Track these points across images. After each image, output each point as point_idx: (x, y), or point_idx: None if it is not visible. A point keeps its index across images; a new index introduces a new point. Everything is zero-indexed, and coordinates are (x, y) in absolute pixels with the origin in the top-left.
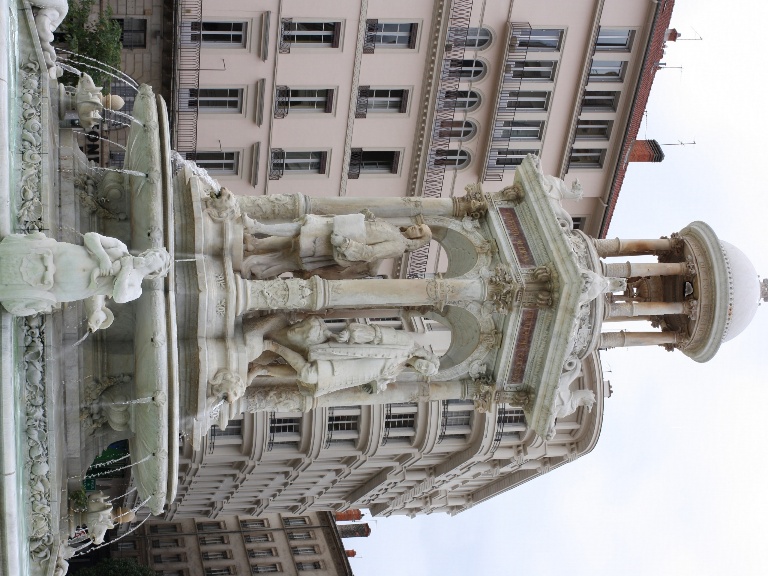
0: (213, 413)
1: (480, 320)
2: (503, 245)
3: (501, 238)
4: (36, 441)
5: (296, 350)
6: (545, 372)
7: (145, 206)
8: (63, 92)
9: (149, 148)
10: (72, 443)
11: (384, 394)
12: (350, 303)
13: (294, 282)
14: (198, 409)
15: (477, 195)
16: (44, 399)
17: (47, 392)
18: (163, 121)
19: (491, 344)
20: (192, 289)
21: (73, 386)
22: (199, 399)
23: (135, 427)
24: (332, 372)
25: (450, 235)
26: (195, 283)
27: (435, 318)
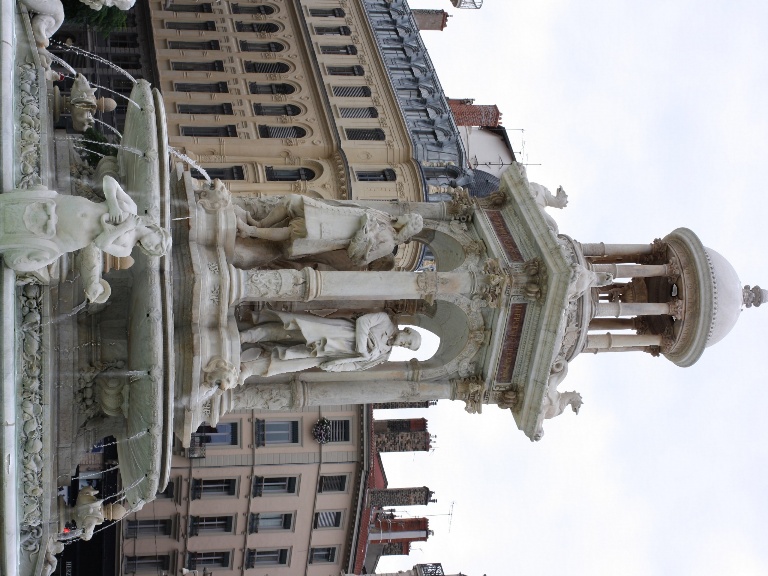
0: None
1: (456, 238)
2: None
3: None
4: (28, 93)
5: None
6: (532, 229)
7: None
8: None
9: None
10: None
11: None
12: None
13: None
14: None
15: None
16: None
17: None
18: None
19: (477, 250)
20: None
21: None
22: (187, 190)
23: (124, 171)
24: (314, 199)
25: None
26: None
27: (445, 361)
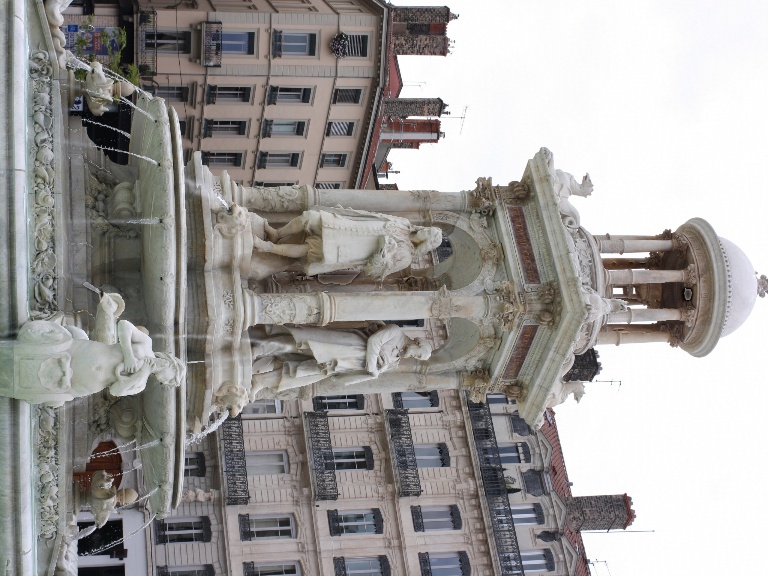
0: (226, 298)
1: (474, 237)
2: None
3: None
4: (42, 127)
5: (298, 237)
6: (552, 246)
7: (139, 99)
8: None
9: None
10: (78, 223)
11: (403, 296)
12: (340, 198)
13: None
14: (205, 226)
15: None
16: (51, 89)
17: (53, 81)
18: None
19: (495, 258)
20: None
21: (78, 163)
22: (204, 215)
23: (141, 205)
24: (333, 215)
25: (437, 271)
26: None
27: (454, 357)
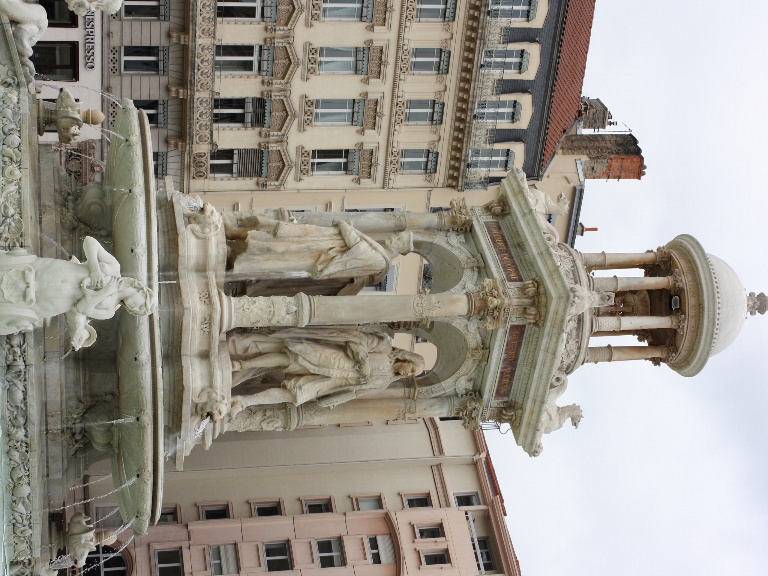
0: None
1: None
2: (490, 372)
3: (493, 364)
4: None
5: None
6: None
7: None
8: (49, 322)
9: (139, 528)
10: None
11: None
12: None
13: (269, 426)
14: None
15: (495, 313)
16: None
17: None
18: (157, 497)
19: None
20: (170, 457)
21: None
22: None
23: None
24: None
25: None
26: (173, 455)
27: None
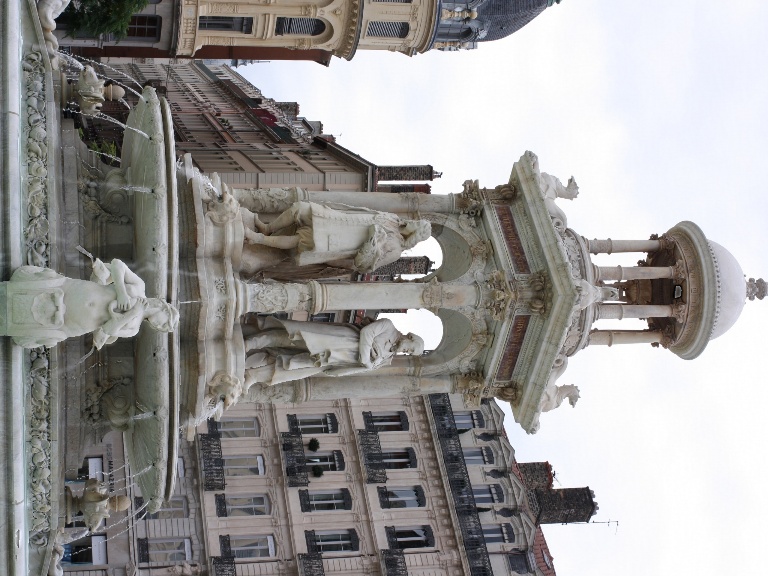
0: (218, 284)
1: (463, 236)
2: None
3: None
4: (35, 109)
5: (289, 232)
6: (541, 238)
7: None
8: None
9: None
10: (70, 204)
11: None
12: (329, 198)
13: None
14: (196, 213)
15: None
16: (43, 78)
17: None
18: None
19: (484, 253)
20: None
21: (71, 152)
22: (195, 202)
23: None
24: None
25: None
26: None
27: (447, 358)
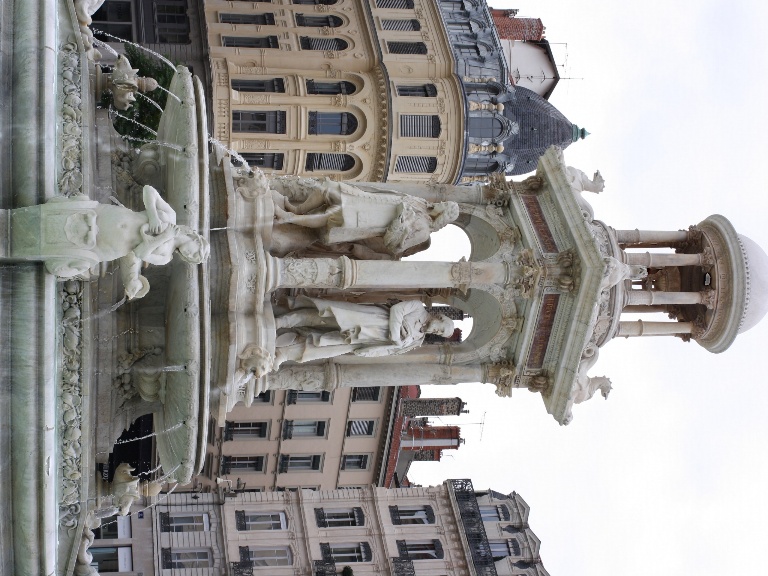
0: (249, 256)
1: (491, 223)
2: None
3: None
4: (70, 81)
5: None
6: (568, 219)
7: None
8: None
9: None
10: (103, 172)
11: None
12: None
13: None
14: (227, 186)
15: None
16: (79, 57)
17: None
18: None
19: (512, 237)
20: None
21: (104, 130)
22: (226, 178)
23: (164, 159)
24: None
25: None
26: None
27: (477, 346)
